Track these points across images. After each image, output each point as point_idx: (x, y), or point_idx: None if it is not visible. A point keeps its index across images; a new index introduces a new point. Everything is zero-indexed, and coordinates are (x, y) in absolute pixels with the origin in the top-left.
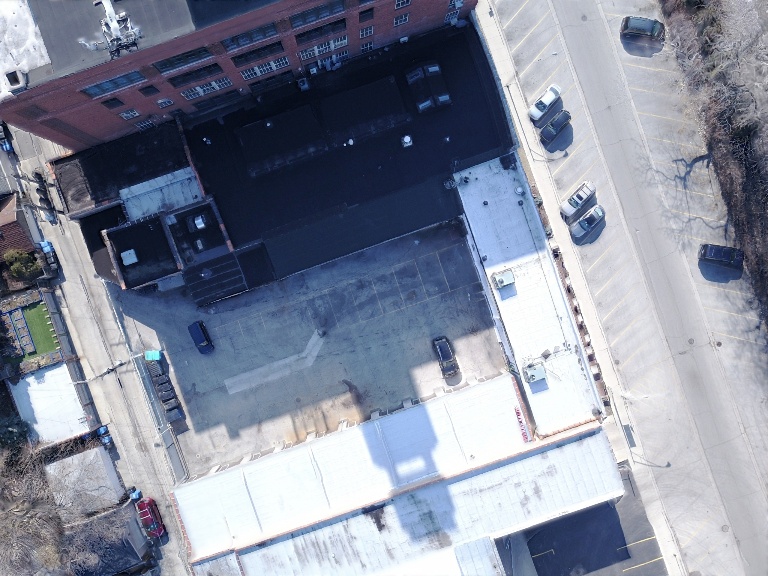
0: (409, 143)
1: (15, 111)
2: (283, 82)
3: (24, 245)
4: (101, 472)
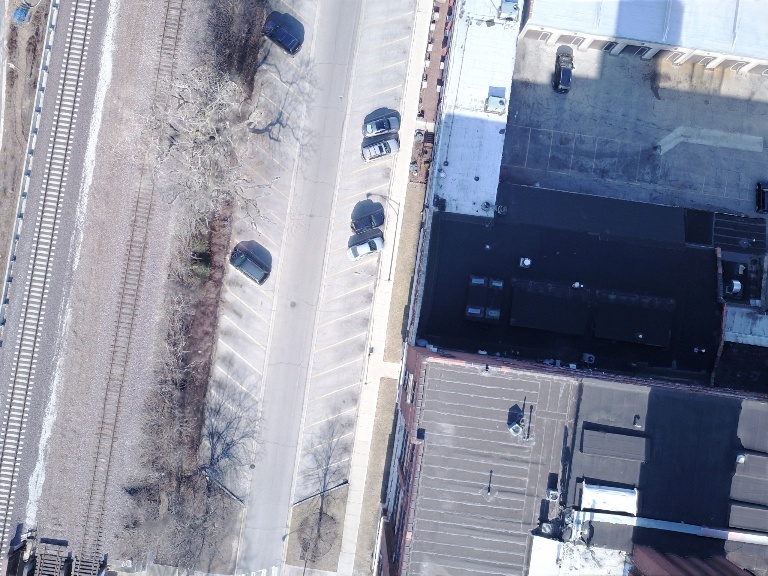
0: None
1: None
2: None
3: None
4: None
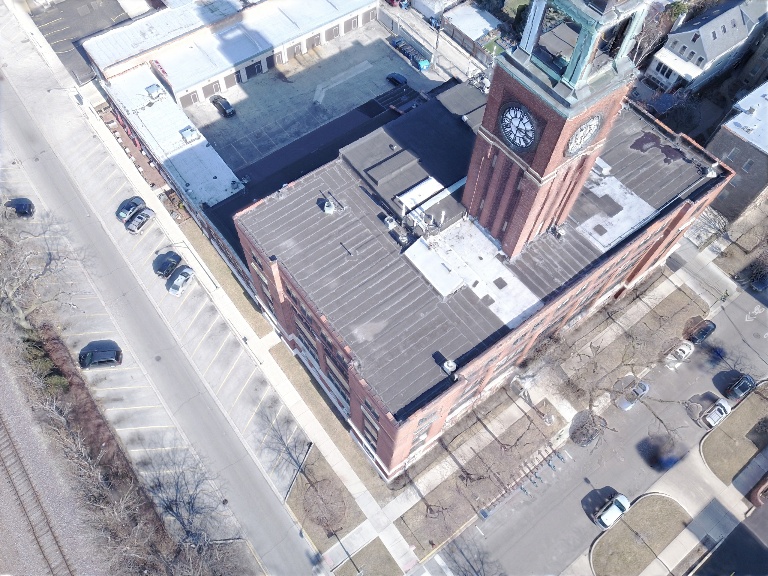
0: None
1: None
2: None
3: None
4: (427, 2)
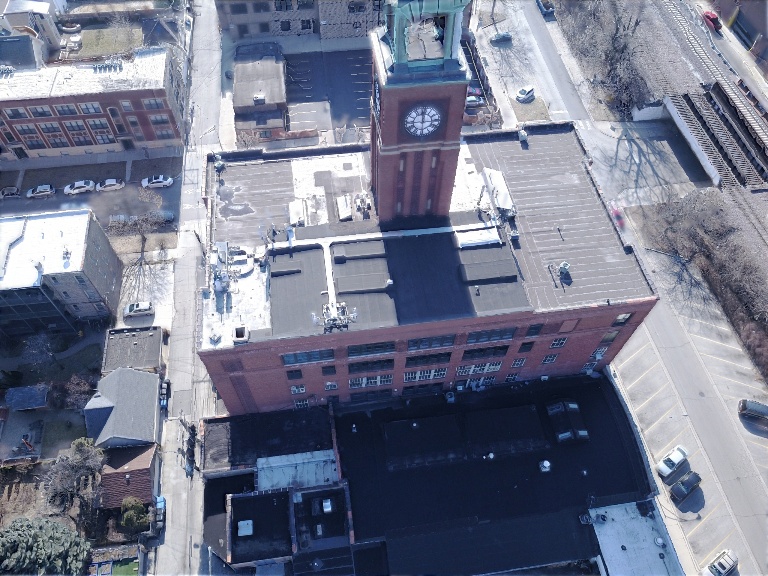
0: (547, 468)
1: (222, 360)
2: (431, 393)
3: (144, 494)
4: None
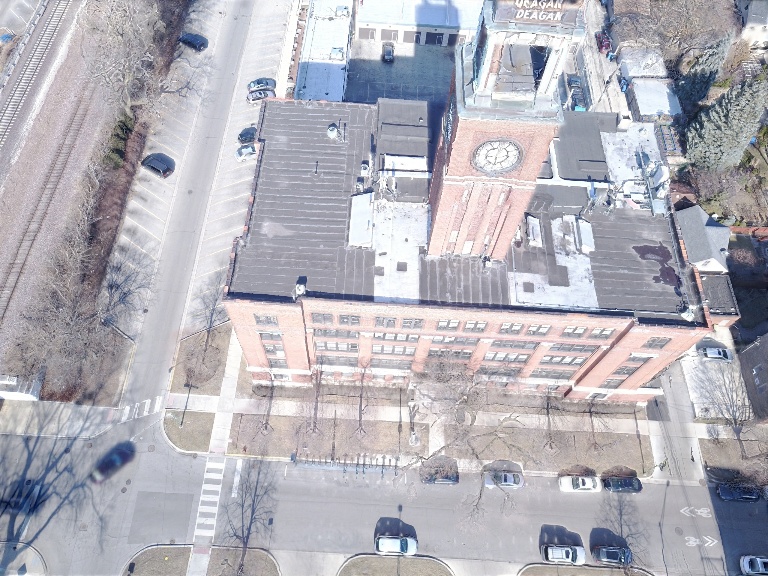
0: None
1: None
2: None
3: None
4: (629, 62)
